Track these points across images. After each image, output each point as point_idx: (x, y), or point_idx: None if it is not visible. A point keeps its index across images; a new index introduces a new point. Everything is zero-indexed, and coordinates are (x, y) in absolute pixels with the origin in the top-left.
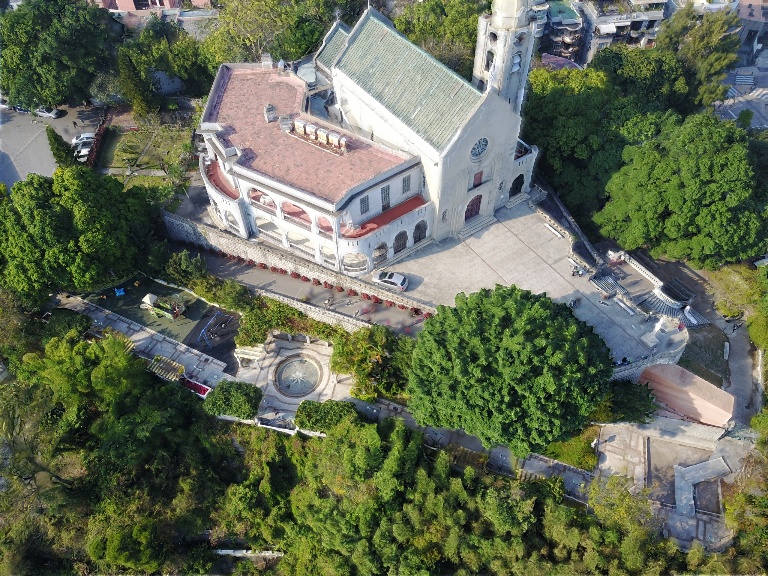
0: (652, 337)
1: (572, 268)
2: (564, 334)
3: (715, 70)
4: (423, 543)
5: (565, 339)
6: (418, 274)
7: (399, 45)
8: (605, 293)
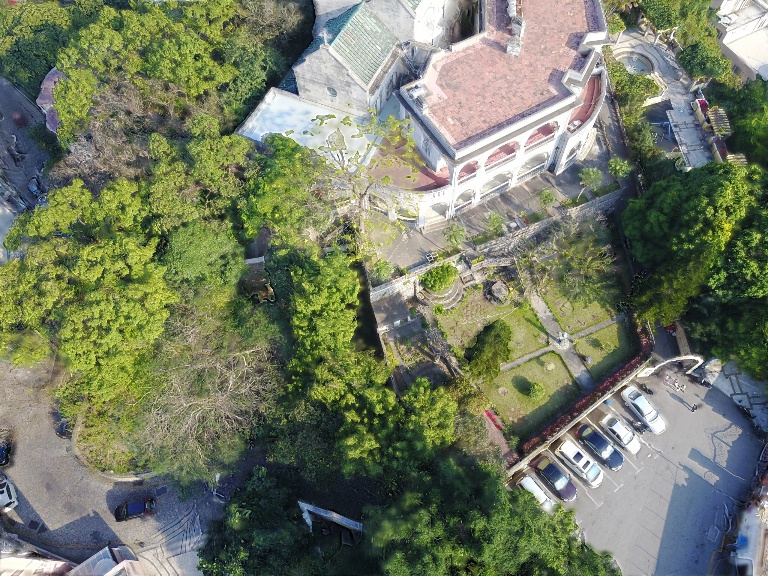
0: None
1: None
2: None
3: None
4: None
5: None
6: None
7: None
8: None
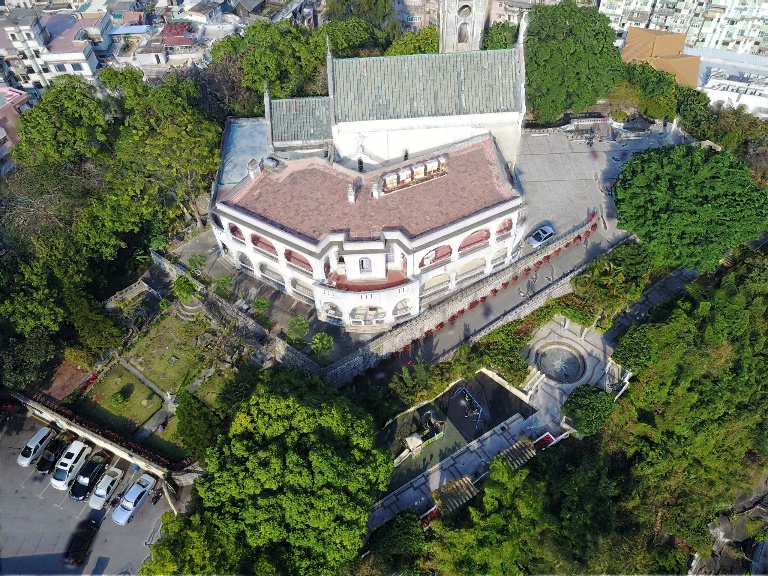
0: (670, 137)
1: (583, 144)
2: (699, 151)
3: (388, 10)
4: (765, 339)
5: (703, 152)
6: (539, 221)
7: (391, 63)
8: (613, 141)
